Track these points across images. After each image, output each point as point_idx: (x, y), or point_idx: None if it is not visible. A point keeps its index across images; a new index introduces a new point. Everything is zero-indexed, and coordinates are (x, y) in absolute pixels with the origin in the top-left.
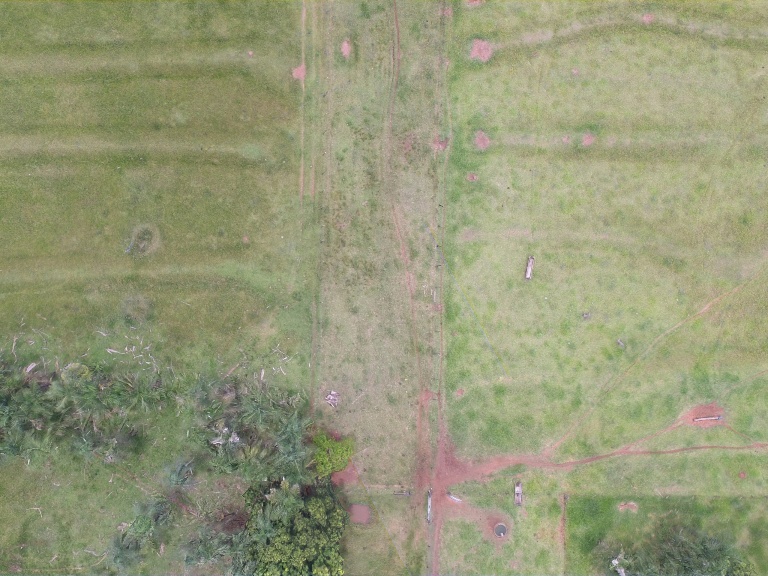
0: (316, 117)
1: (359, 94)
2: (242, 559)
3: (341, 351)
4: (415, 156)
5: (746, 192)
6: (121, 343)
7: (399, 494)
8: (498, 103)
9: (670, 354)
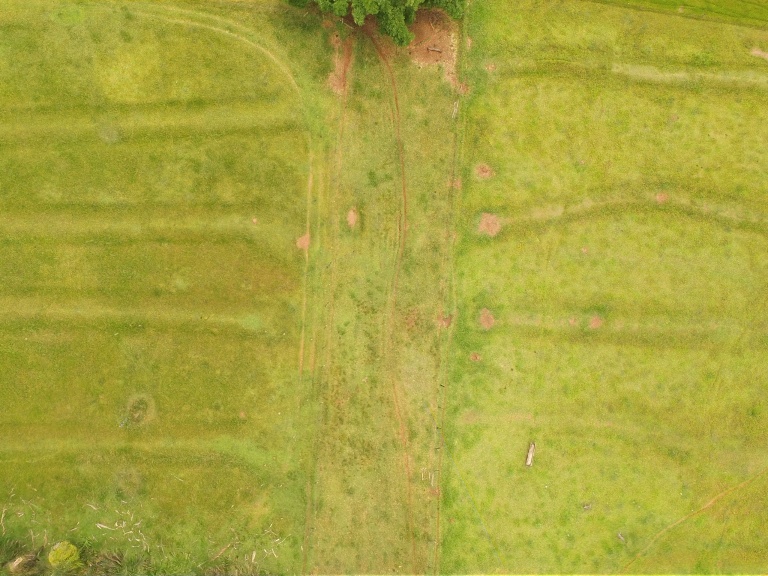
0: (319, 288)
1: (363, 265)
2: None
3: (335, 534)
4: (418, 332)
5: (756, 383)
6: (111, 518)
7: None
8: (504, 280)
9: (672, 550)
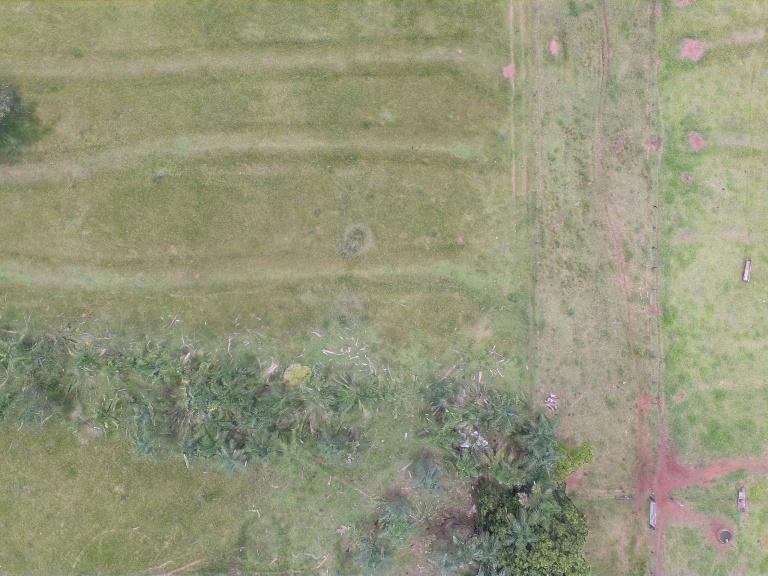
0: (526, 116)
1: (569, 93)
2: (495, 564)
3: (558, 353)
4: (628, 156)
5: None
6: (336, 344)
7: (621, 499)
8: (711, 103)
9: None
